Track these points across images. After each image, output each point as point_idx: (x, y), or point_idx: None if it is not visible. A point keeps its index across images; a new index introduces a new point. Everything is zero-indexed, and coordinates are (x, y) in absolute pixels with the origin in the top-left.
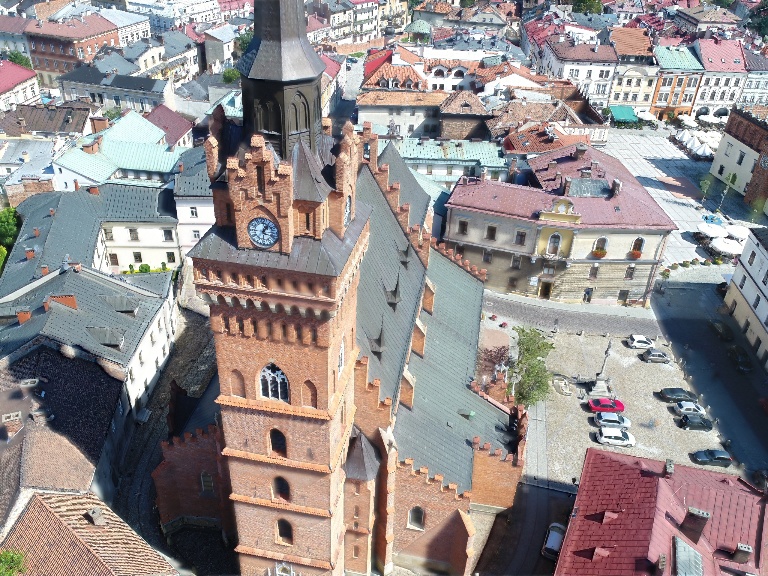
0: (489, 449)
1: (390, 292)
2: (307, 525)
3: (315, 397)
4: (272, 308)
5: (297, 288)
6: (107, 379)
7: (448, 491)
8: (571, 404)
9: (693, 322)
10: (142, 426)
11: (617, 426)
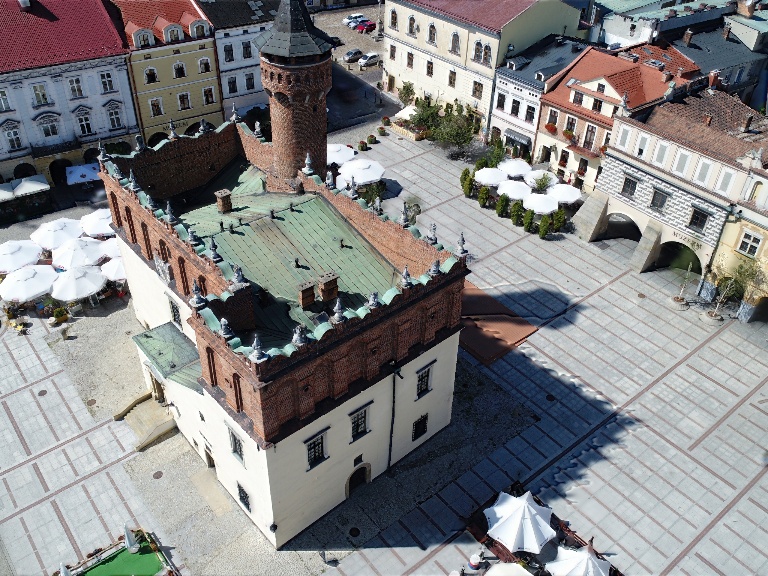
0: None
1: None
2: None
3: None
4: None
5: None
6: None
7: None
8: None
9: (339, 90)
10: None
11: None
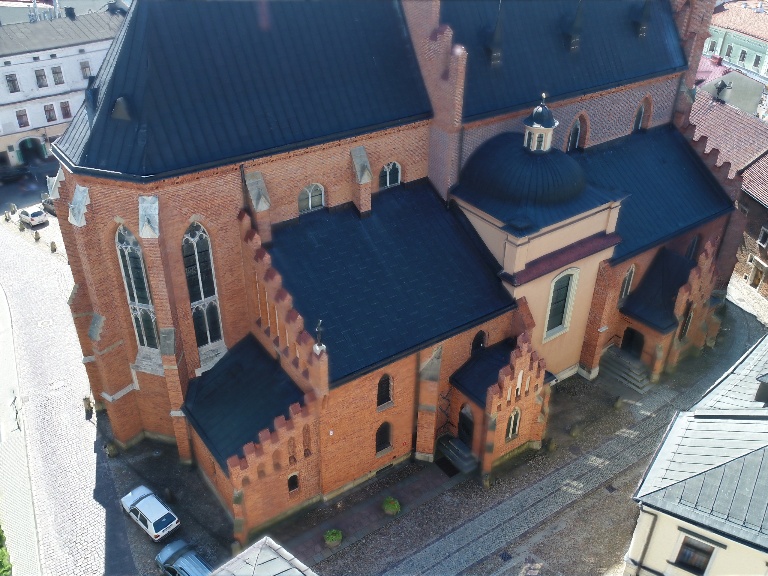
0: None
1: None
2: None
3: None
4: None
5: None
6: None
7: None
8: None
9: None
10: None
11: None
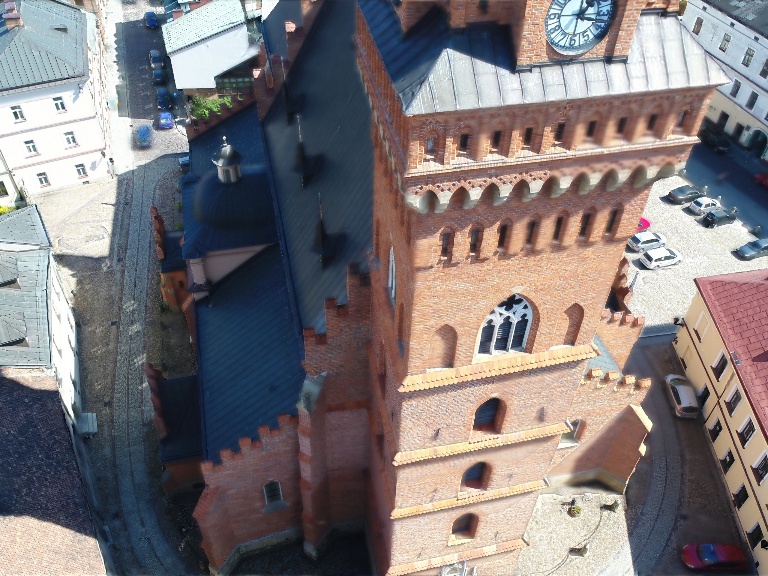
0: (608, 316)
1: None
2: (502, 508)
3: (573, 328)
4: (564, 188)
5: (625, 131)
6: (32, 396)
7: (623, 388)
8: None
9: None
10: (93, 439)
11: (655, 245)
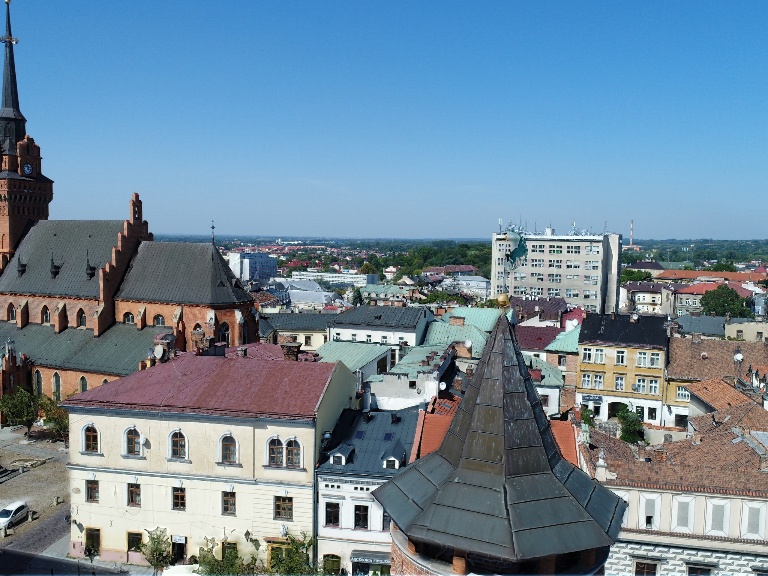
0: None
1: (56, 266)
2: None
3: None
4: None
5: None
6: None
7: None
8: (1, 461)
9: None
10: None
11: None
